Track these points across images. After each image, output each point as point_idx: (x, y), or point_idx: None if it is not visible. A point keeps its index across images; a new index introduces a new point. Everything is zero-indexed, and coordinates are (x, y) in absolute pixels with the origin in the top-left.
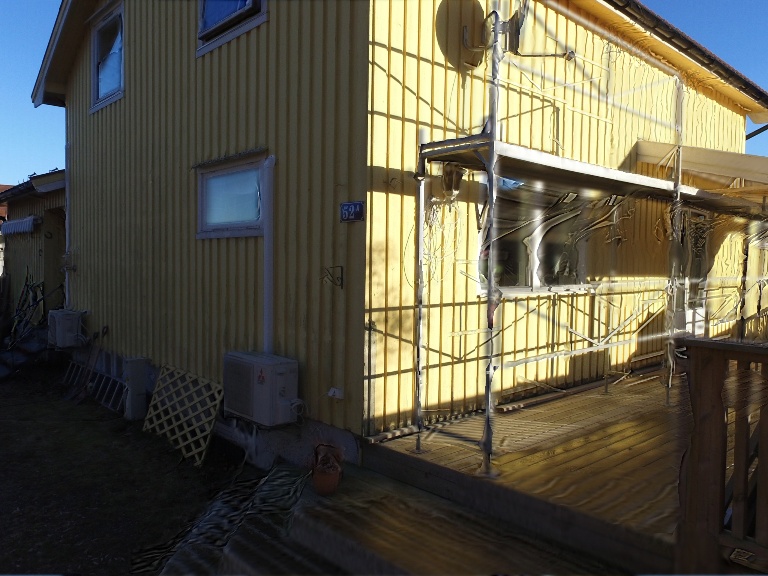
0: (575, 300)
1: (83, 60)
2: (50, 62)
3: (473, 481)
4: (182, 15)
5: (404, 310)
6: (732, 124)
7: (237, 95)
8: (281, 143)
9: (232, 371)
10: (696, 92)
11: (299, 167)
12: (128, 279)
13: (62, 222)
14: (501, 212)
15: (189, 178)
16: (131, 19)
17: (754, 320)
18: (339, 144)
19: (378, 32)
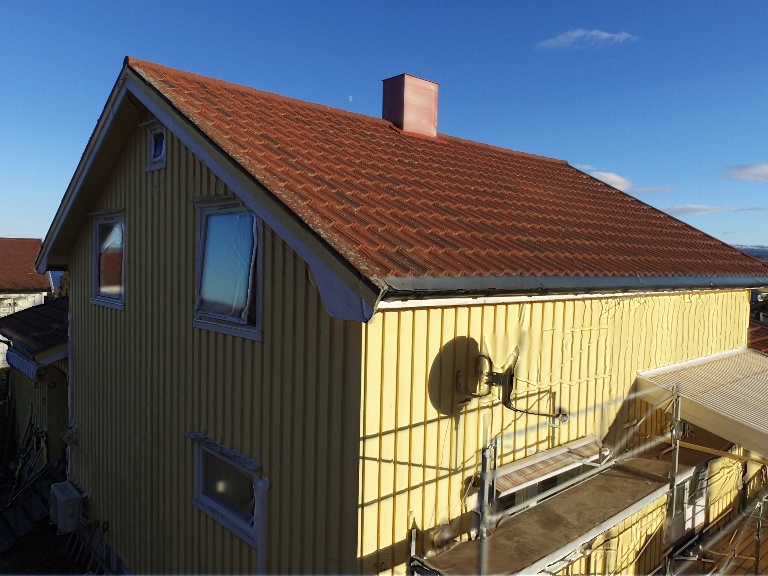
0: (570, 568)
1: (85, 244)
2: (53, 243)
3: None
4: (180, 272)
5: None
6: (736, 304)
7: (232, 392)
8: (274, 472)
9: None
10: (698, 294)
11: (292, 509)
12: (127, 492)
13: (65, 375)
14: None
15: (186, 438)
16: (131, 239)
17: (757, 476)
18: (330, 515)
19: (369, 426)
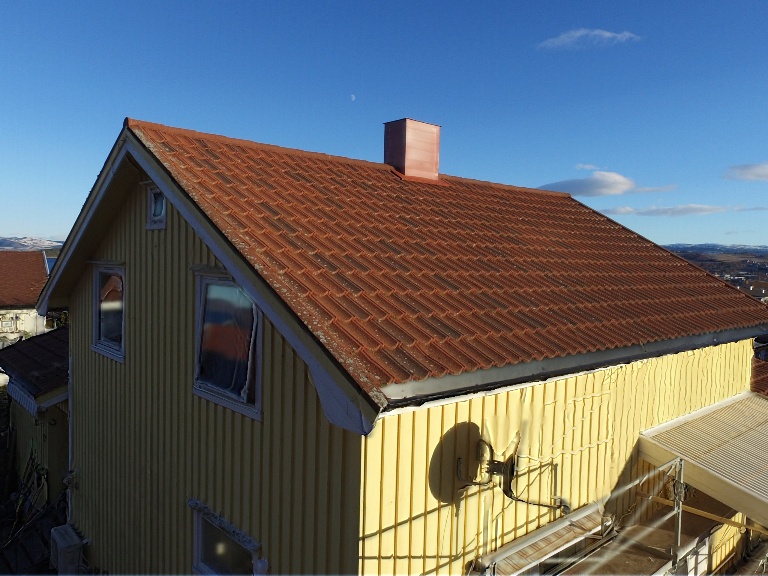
0: None
1: (85, 290)
2: (53, 288)
3: None
4: (180, 336)
5: None
6: (739, 350)
7: (232, 467)
8: (274, 555)
9: None
10: None
11: None
12: (127, 546)
13: None
14: None
15: (186, 503)
16: (131, 293)
17: None
18: None
19: (369, 525)
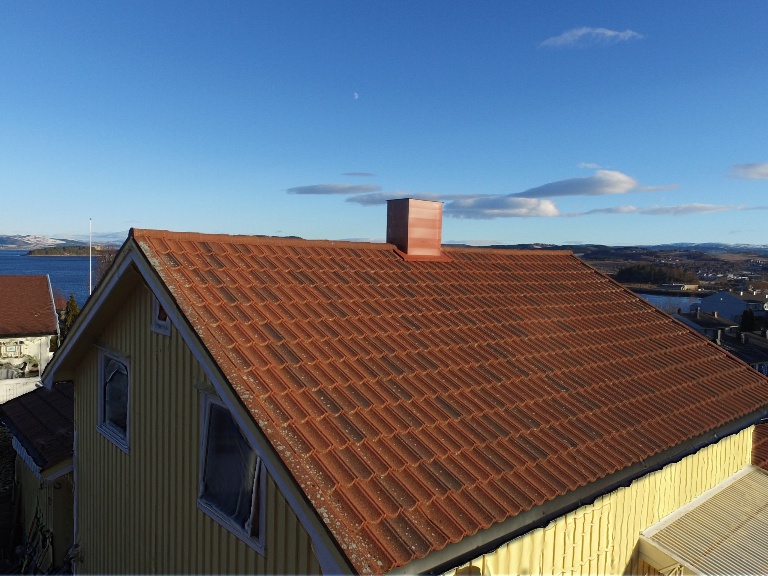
0: None
1: (90, 369)
2: (58, 366)
3: None
4: (184, 446)
5: None
6: None
7: None
8: None
9: None
10: None
11: None
12: None
13: None
14: None
15: None
16: (136, 387)
17: None
18: None
19: None
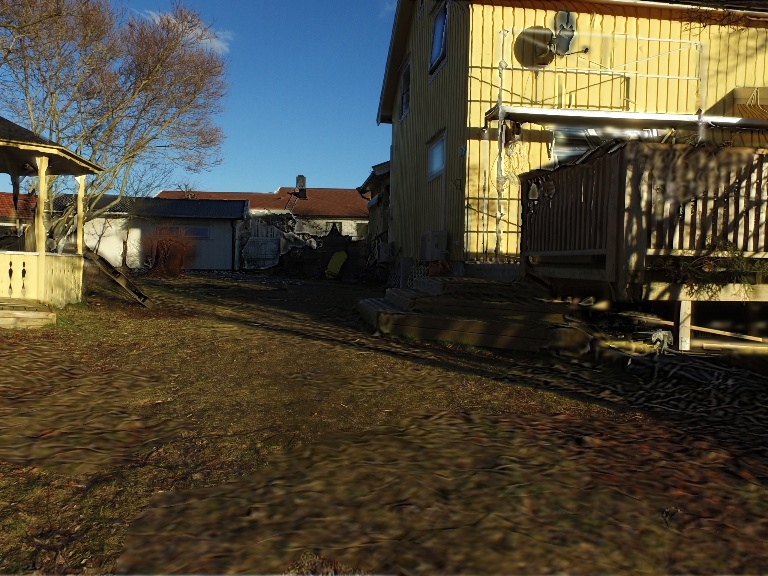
0: None
1: (398, 93)
2: (383, 98)
3: (487, 266)
4: None
5: (491, 200)
6: None
7: (439, 102)
8: None
9: (422, 240)
10: None
11: None
12: (408, 216)
13: None
14: (560, 146)
15: None
16: None
17: None
18: None
19: (474, 61)
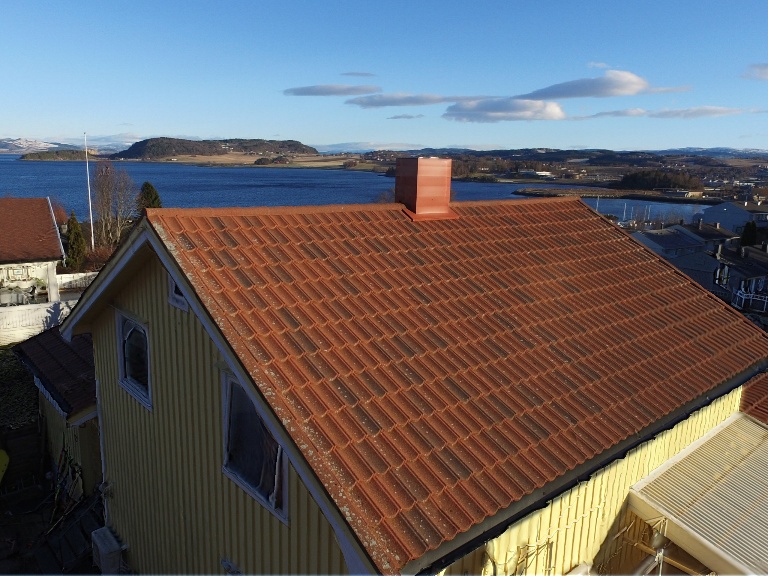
0: None
1: (108, 326)
2: (77, 322)
3: None
4: (207, 415)
5: None
6: None
7: (262, 551)
8: None
9: None
10: None
11: None
12: (165, 568)
13: None
14: None
15: (219, 559)
16: (156, 352)
17: None
18: None
19: None
